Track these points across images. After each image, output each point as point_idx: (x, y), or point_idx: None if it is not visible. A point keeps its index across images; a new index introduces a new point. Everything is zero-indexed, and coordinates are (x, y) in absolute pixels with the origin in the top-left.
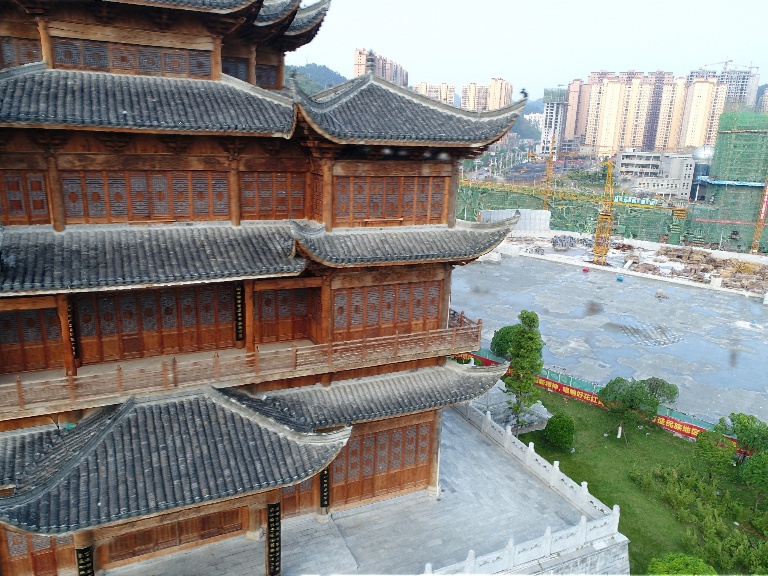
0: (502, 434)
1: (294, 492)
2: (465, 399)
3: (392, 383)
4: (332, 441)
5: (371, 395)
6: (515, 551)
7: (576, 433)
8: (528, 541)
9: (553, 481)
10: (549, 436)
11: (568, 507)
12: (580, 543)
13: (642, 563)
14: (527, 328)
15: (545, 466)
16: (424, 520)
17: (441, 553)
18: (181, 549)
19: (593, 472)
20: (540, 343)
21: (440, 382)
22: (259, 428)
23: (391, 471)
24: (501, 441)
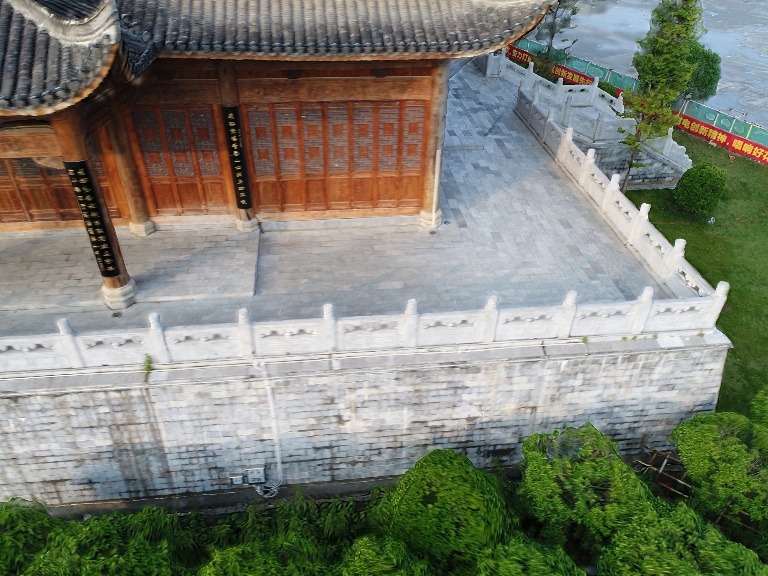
0: (580, 162)
1: (193, 177)
2: (470, 48)
3: (339, 4)
4: (97, 35)
5: (292, 18)
6: (499, 317)
7: (728, 201)
8: (528, 307)
9: (633, 236)
10: (679, 195)
11: (642, 277)
12: (633, 330)
13: (758, 386)
14: (680, 1)
15: (627, 212)
16: (393, 254)
17: (391, 300)
18: (36, 227)
19: (732, 253)
20: (697, 30)
21: (433, 14)
22: (11, 12)
23: (356, 175)
24: (577, 174)
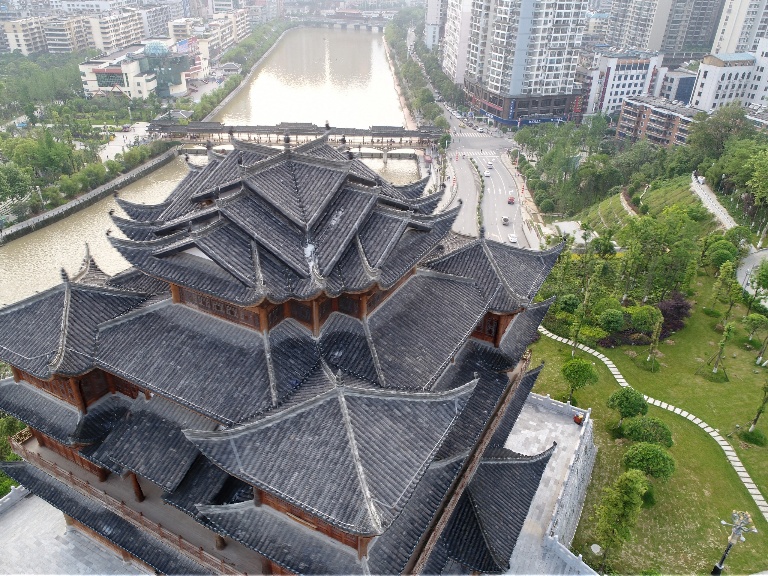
0: None
1: None
2: None
3: None
4: None
5: None
6: None
7: None
8: (2, 499)
9: None
10: None
11: None
12: None
13: None
14: None
15: None
16: None
17: None
18: None
19: None
20: None
21: None
22: None
23: None
24: None
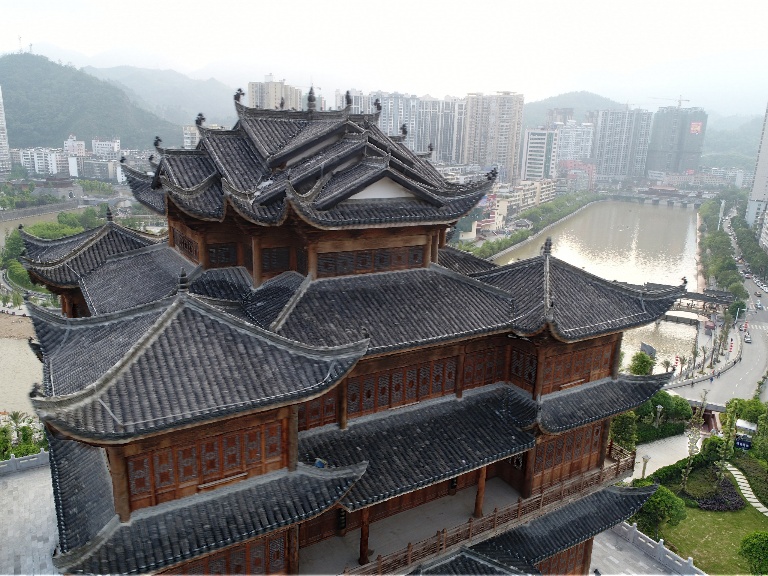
0: None
1: None
2: None
3: None
4: None
5: None
6: None
7: None
8: None
9: None
10: None
11: None
12: None
13: None
14: None
15: None
16: None
17: None
18: None
19: None
20: None
21: None
22: None
23: None
24: None
